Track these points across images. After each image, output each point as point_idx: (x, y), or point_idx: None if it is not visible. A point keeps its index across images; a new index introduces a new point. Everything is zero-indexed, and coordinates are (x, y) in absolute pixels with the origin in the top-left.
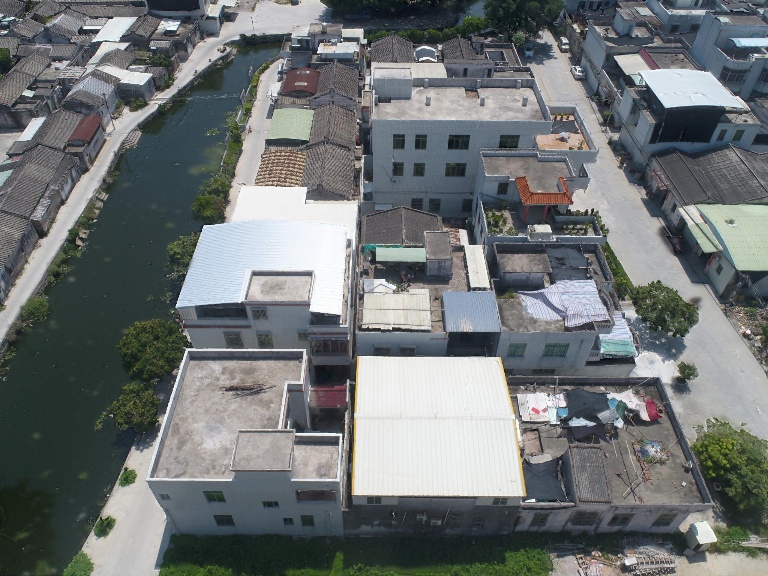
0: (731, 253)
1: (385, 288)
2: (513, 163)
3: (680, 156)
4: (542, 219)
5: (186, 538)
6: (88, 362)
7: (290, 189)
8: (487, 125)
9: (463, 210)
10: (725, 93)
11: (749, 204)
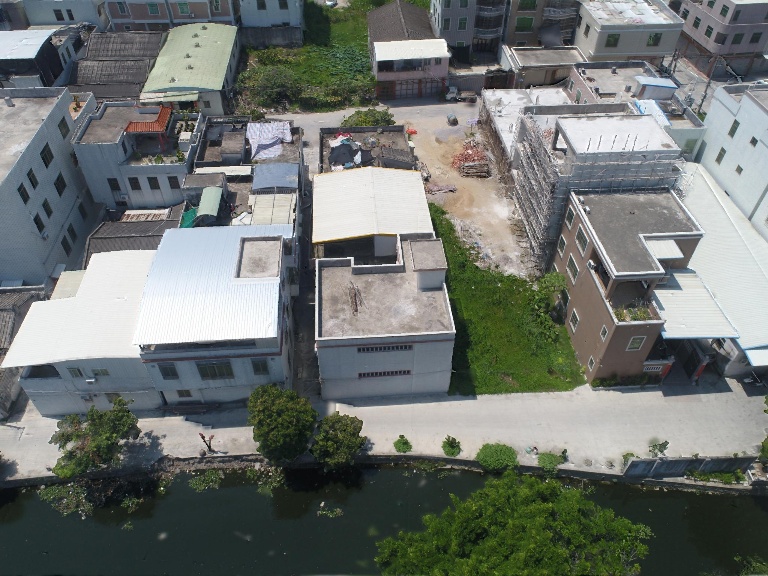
0: (205, 88)
1: (245, 218)
2: (96, 132)
3: (75, 85)
4: (163, 142)
5: (450, 384)
6: (238, 568)
7: (32, 316)
8: (48, 123)
9: (83, 219)
10: (27, 31)
11: (150, 73)
